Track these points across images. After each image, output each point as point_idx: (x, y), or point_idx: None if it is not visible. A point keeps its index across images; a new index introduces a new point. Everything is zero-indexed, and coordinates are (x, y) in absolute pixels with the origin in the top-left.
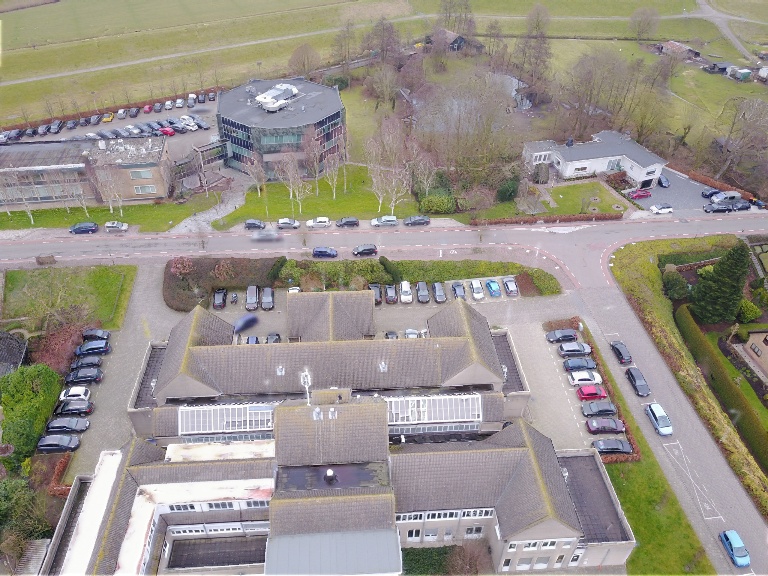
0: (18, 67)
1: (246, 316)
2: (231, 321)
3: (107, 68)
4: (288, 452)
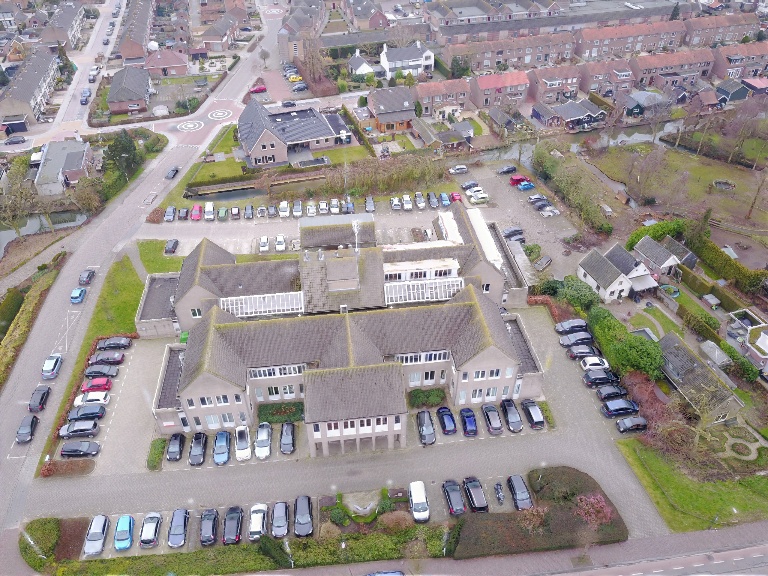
0: None
1: (474, 471)
2: (489, 462)
3: None
4: None
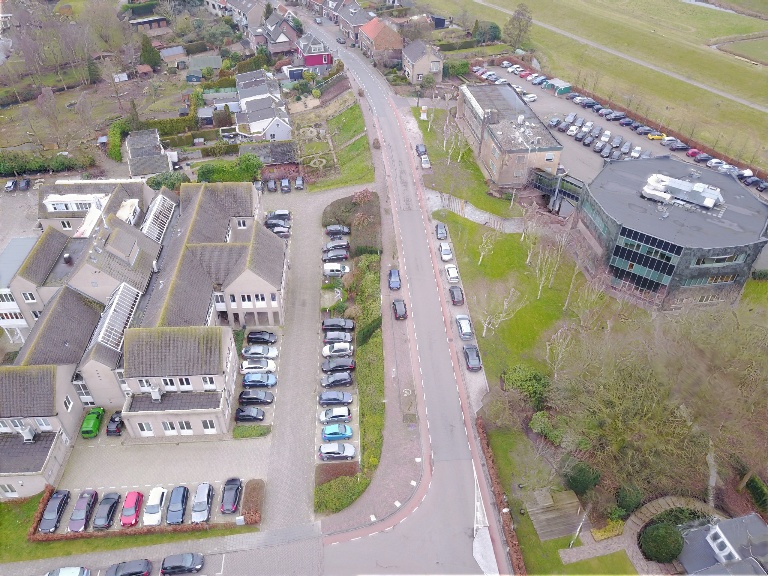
0: (711, 72)
1: (316, 248)
2: (310, 241)
3: (765, 112)
4: None
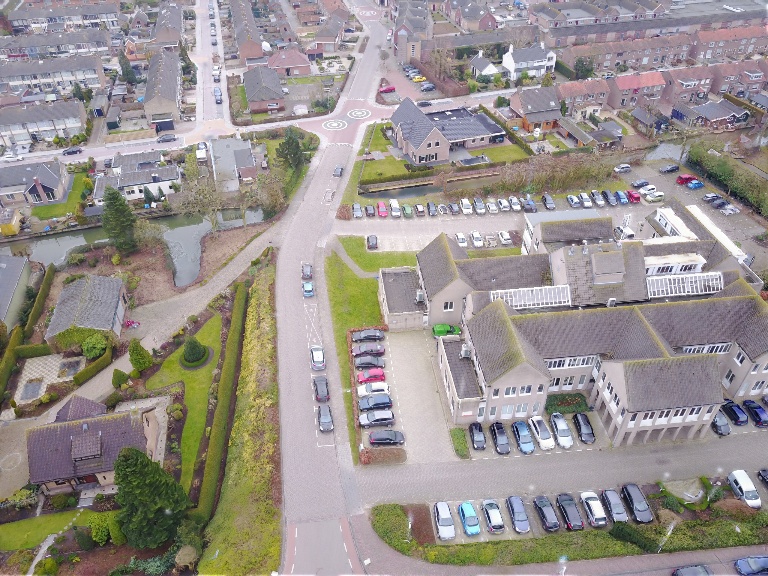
0: None
1: None
2: None
3: None
4: None
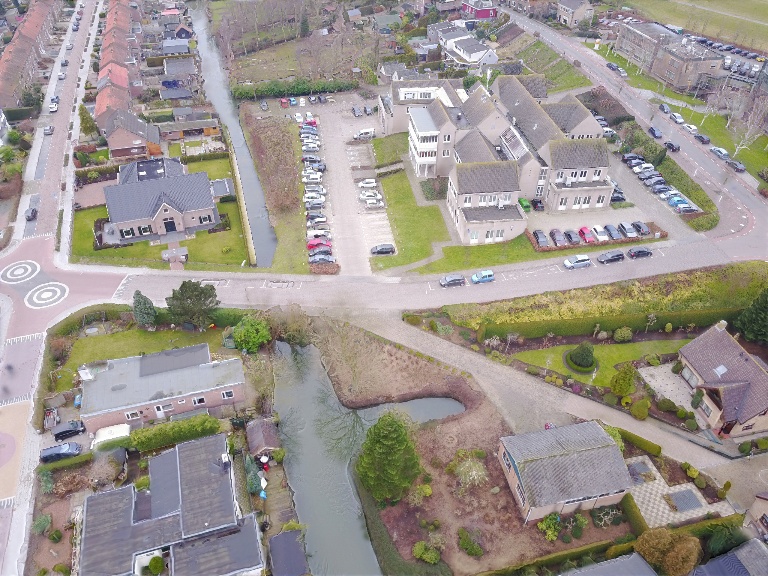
0: None
1: None
2: None
3: None
4: (466, 104)
